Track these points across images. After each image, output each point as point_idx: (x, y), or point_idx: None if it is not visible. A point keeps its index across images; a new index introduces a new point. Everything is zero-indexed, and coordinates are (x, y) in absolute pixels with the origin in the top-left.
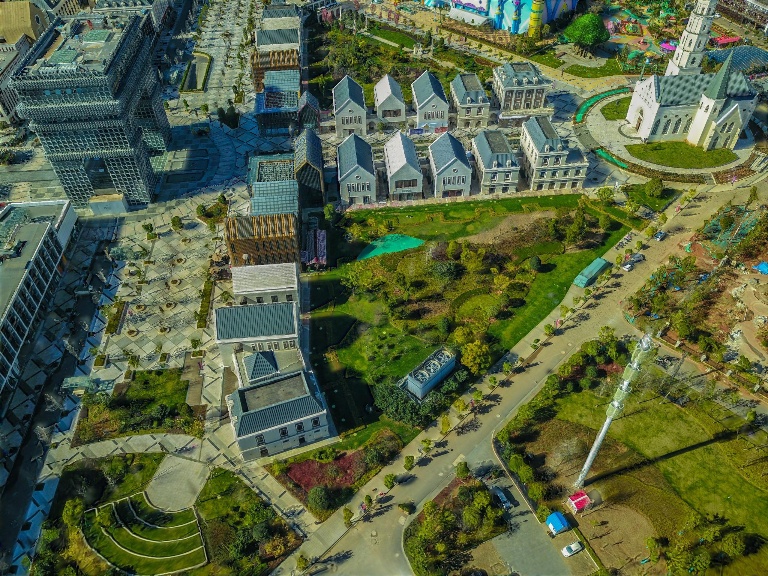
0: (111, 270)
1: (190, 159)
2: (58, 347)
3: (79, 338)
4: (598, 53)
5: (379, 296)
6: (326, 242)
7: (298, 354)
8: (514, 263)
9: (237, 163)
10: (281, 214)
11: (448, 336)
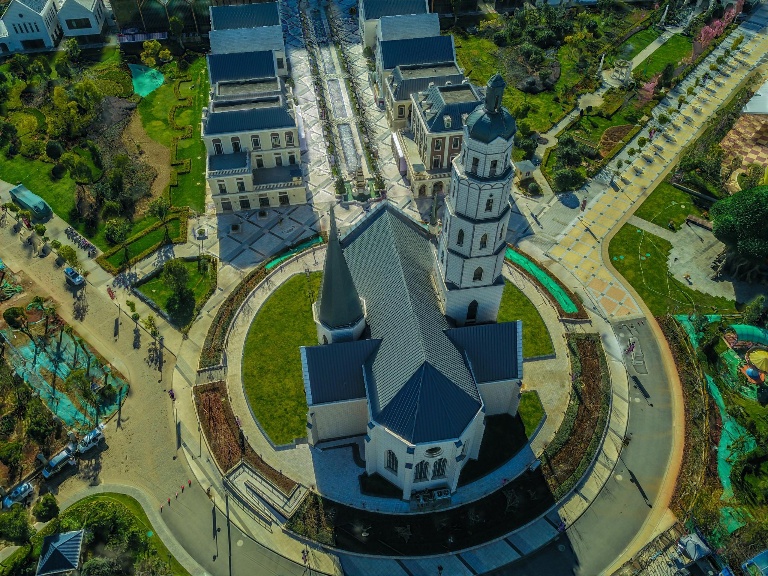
0: None
1: None
2: None
3: None
4: (758, 287)
5: None
6: (162, 47)
7: (2, 35)
8: (76, 146)
9: None
10: None
11: None
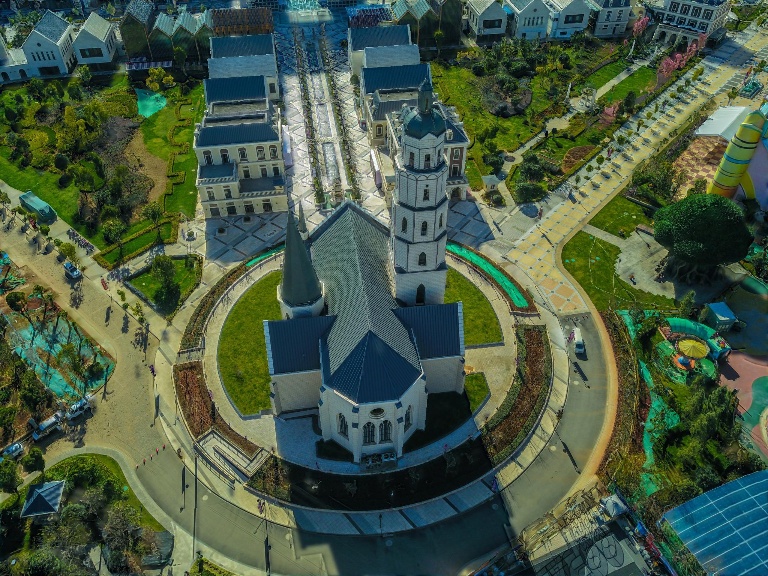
0: (173, 14)
1: (315, 17)
2: (104, 12)
3: (109, 16)
4: (697, 287)
5: (82, 98)
6: (167, 74)
7: (22, 62)
8: (82, 160)
9: (305, 33)
10: (130, 8)
11: (7, 124)
